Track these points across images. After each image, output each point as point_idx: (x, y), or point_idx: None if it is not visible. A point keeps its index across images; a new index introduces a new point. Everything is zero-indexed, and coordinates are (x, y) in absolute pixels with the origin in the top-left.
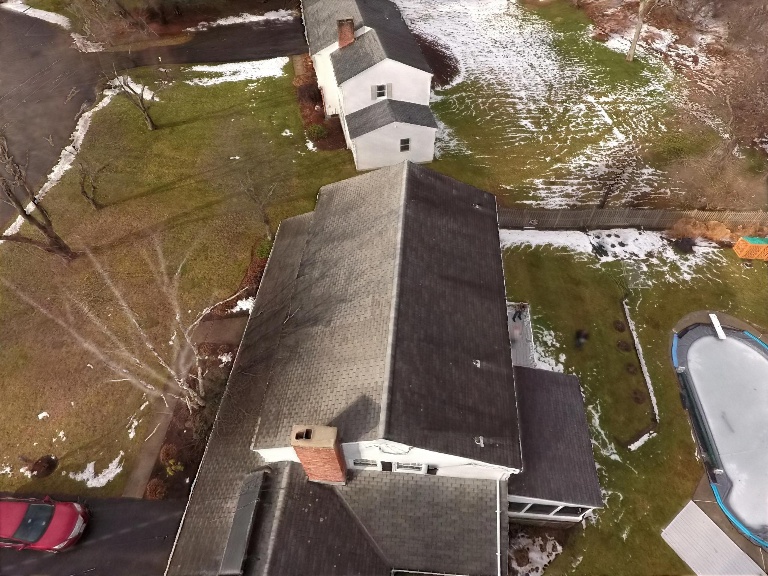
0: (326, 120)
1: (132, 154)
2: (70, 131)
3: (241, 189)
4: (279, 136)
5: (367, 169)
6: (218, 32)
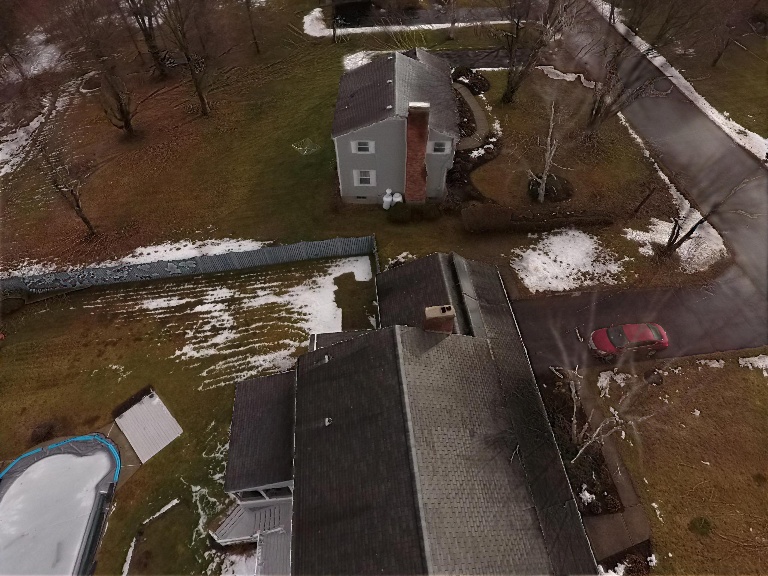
0: None
1: None
2: None
3: None
4: None
5: None
6: None
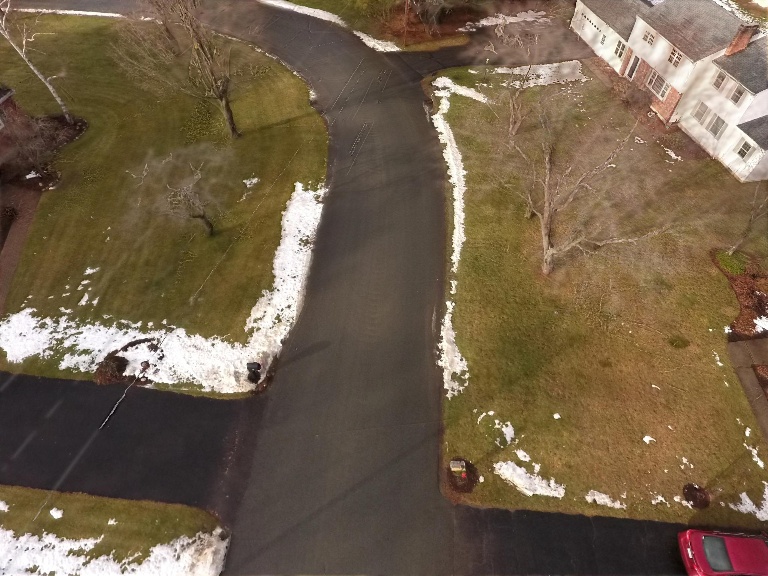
0: (668, 128)
1: (515, 160)
2: (434, 134)
3: (646, 199)
4: (635, 143)
5: (752, 181)
6: (489, 33)
